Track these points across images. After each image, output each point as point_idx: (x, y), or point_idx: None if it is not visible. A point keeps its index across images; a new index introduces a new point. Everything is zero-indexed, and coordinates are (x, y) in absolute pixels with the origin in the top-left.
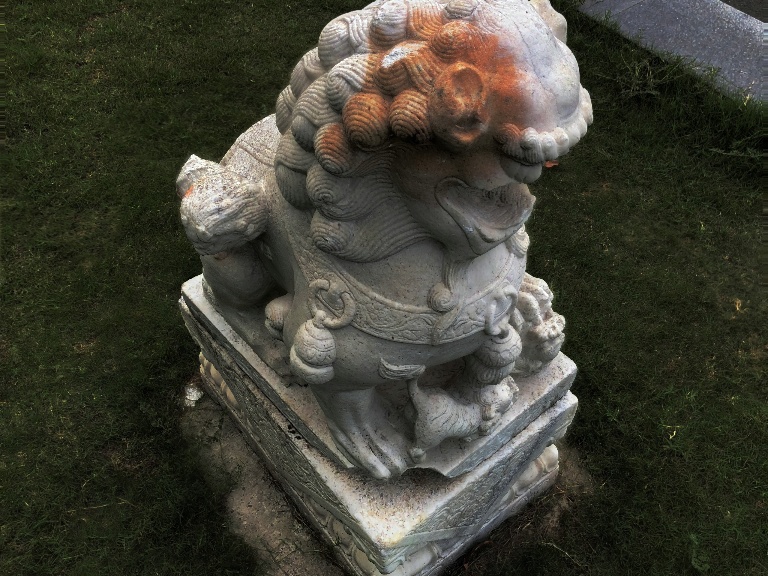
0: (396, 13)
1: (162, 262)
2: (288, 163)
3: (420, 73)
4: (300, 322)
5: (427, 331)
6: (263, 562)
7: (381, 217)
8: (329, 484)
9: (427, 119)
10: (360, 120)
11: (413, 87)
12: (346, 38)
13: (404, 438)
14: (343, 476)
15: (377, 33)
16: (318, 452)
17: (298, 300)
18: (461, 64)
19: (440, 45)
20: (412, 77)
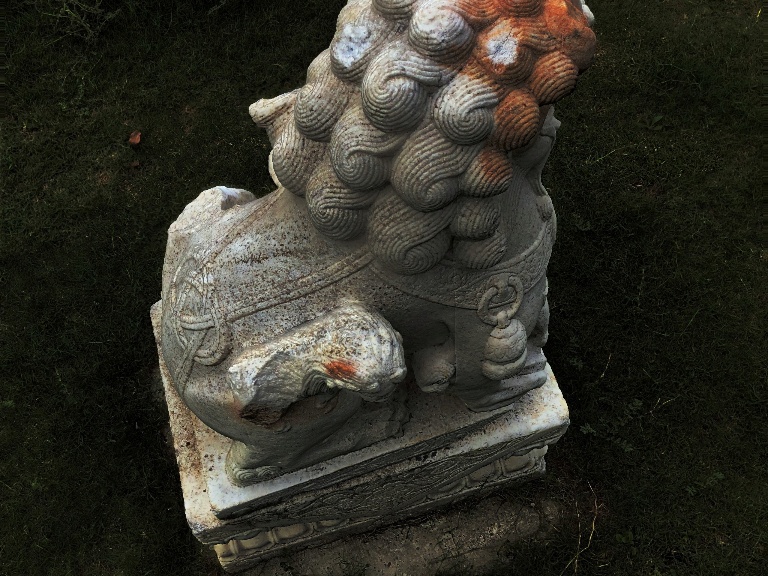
0: (452, 22)
1: (27, 575)
2: (427, 237)
3: (538, 39)
4: (482, 344)
5: (550, 239)
6: (453, 568)
7: (505, 194)
8: (492, 443)
9: (574, 65)
10: (528, 120)
11: (541, 55)
12: (417, 86)
13: (527, 342)
14: (490, 428)
15: (451, 52)
16: (457, 441)
17: (467, 333)
18: (559, 2)
19: (528, 6)
20: (537, 48)
